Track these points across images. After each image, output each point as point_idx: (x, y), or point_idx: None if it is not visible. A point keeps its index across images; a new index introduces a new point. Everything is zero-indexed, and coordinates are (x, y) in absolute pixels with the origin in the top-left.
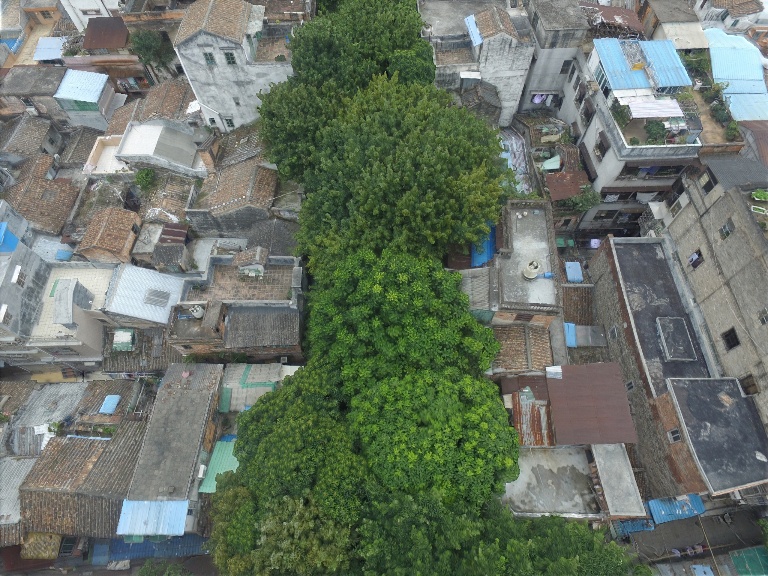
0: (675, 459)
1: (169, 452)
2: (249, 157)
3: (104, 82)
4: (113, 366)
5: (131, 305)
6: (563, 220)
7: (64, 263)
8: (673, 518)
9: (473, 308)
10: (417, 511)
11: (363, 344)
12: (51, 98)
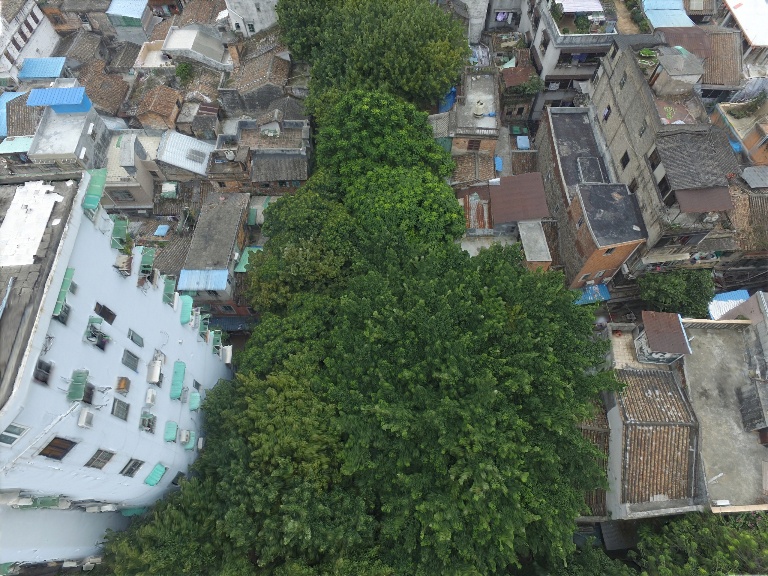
0: (580, 240)
1: (213, 242)
2: (267, 51)
3: (146, 4)
4: (161, 210)
5: (177, 159)
6: (517, 108)
7: (123, 130)
8: (586, 302)
9: (436, 137)
10: (390, 238)
11: (355, 149)
12: (104, 14)
